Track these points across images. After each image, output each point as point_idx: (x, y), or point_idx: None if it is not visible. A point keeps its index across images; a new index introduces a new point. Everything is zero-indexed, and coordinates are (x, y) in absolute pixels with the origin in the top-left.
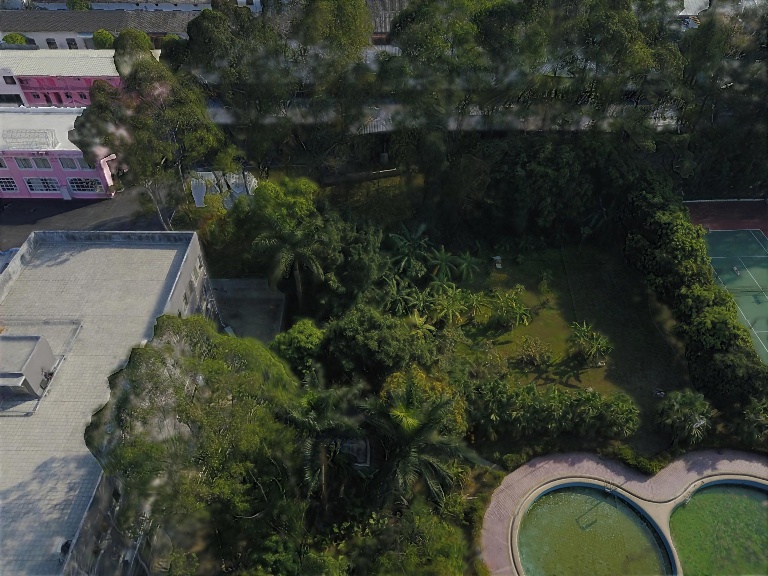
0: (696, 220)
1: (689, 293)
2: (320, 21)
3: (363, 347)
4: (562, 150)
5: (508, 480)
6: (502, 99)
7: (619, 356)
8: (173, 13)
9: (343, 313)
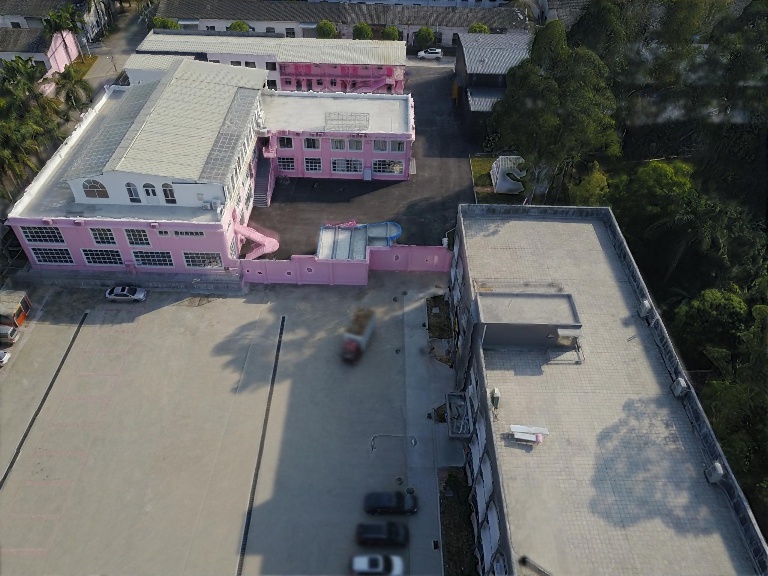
0: None
1: None
2: (694, 17)
3: None
4: None
5: None
6: None
7: None
8: (387, 6)
9: (724, 285)
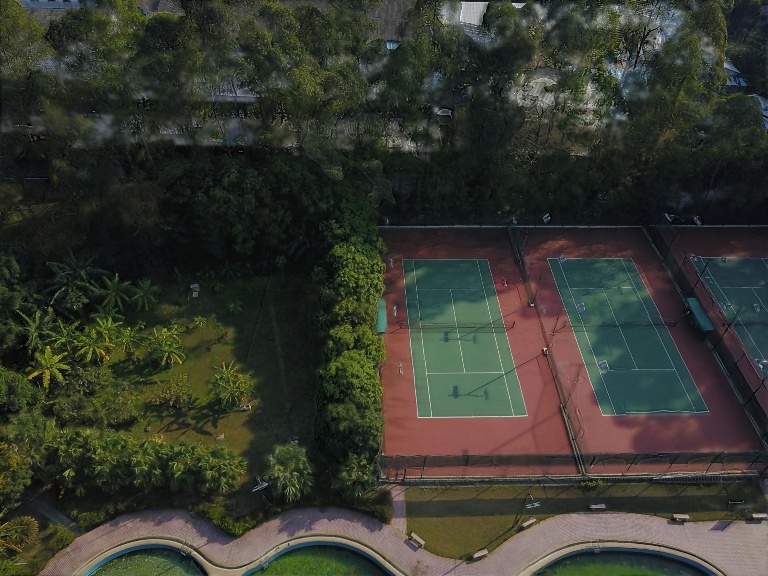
0: (427, 247)
1: (334, 334)
2: None
3: None
4: (249, 174)
5: (78, 542)
6: (184, 118)
7: (271, 399)
8: None
9: None
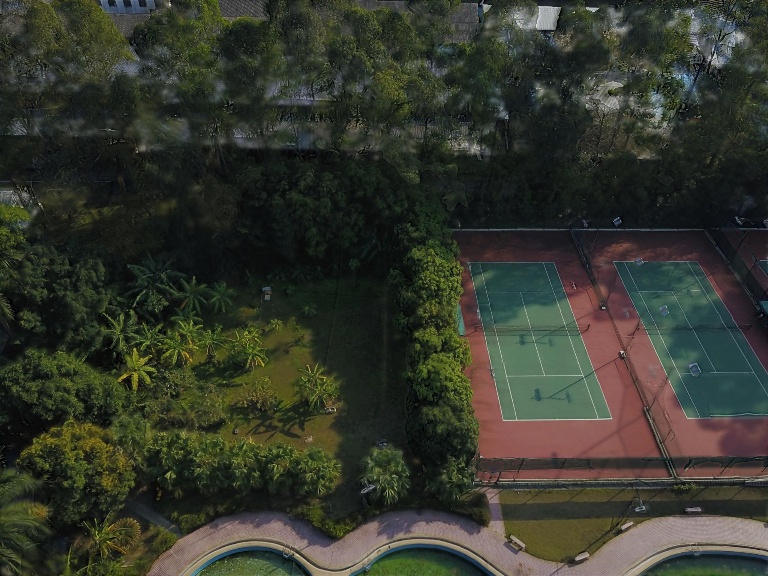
0: (492, 250)
1: (420, 337)
2: (36, 36)
3: (19, 399)
4: (325, 178)
5: (180, 544)
6: (261, 122)
7: (355, 401)
8: None
9: (46, 354)
